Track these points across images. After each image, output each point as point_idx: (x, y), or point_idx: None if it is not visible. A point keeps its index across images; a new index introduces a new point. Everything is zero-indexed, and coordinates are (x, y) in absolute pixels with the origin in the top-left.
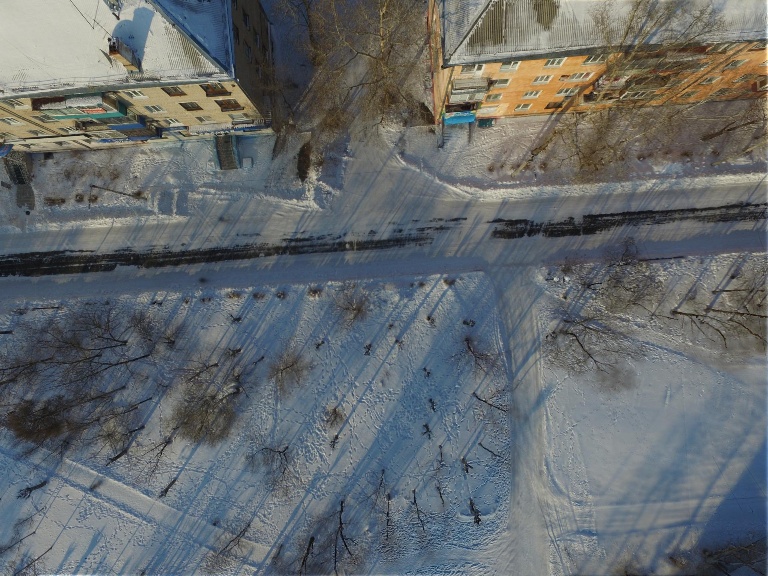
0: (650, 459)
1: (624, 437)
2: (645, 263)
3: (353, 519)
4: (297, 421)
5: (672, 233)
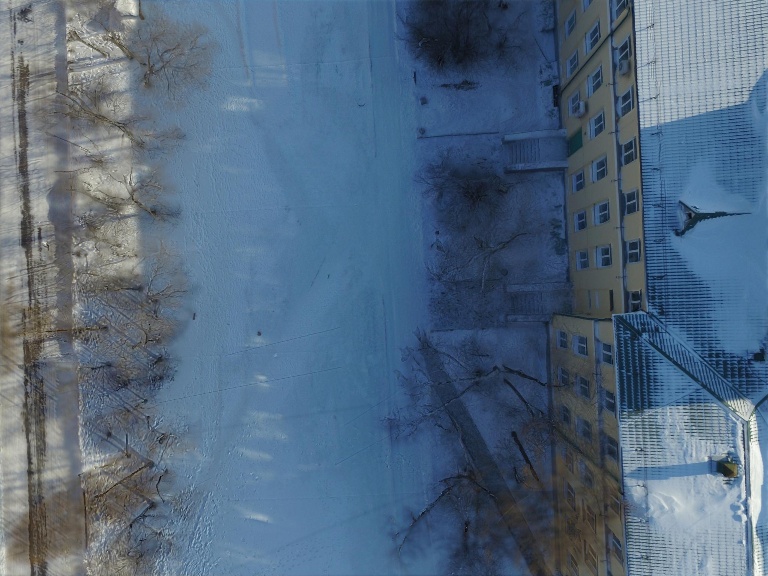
0: (338, 544)
1: None
2: (88, 543)
3: None
4: None
5: (57, 500)
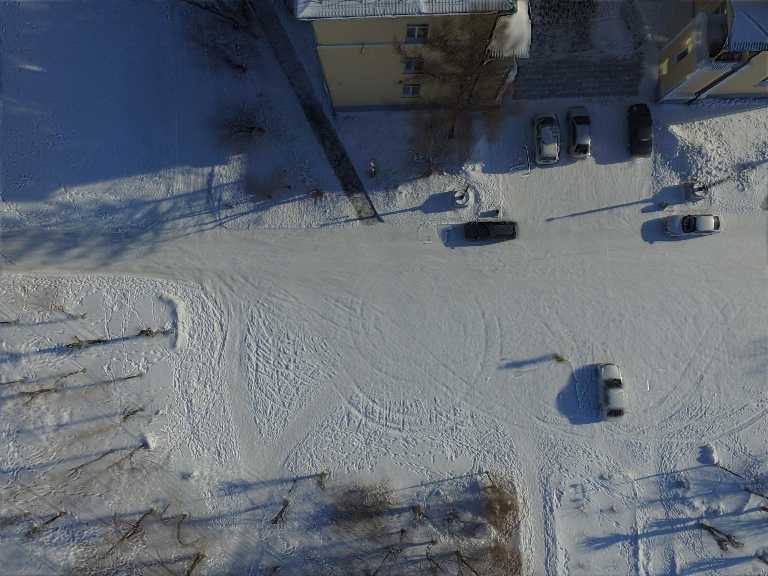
0: (114, 94)
1: (82, 126)
2: None
3: (175, 496)
4: (38, 569)
5: None
